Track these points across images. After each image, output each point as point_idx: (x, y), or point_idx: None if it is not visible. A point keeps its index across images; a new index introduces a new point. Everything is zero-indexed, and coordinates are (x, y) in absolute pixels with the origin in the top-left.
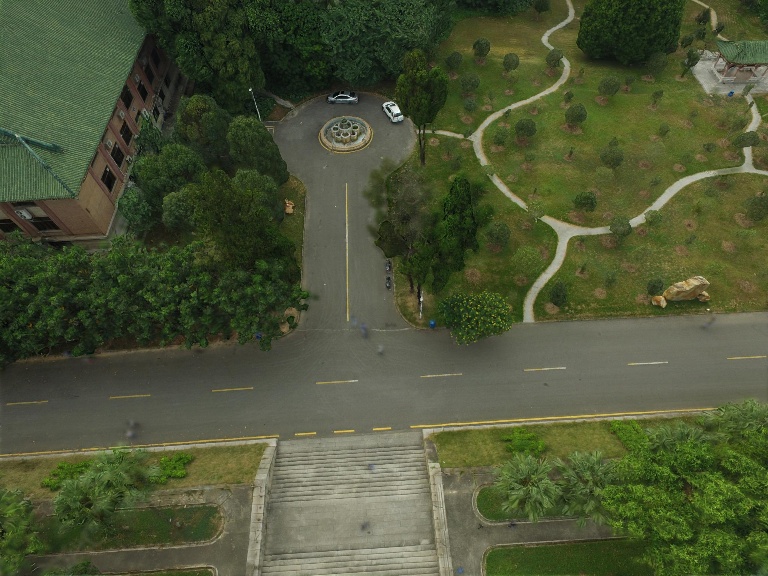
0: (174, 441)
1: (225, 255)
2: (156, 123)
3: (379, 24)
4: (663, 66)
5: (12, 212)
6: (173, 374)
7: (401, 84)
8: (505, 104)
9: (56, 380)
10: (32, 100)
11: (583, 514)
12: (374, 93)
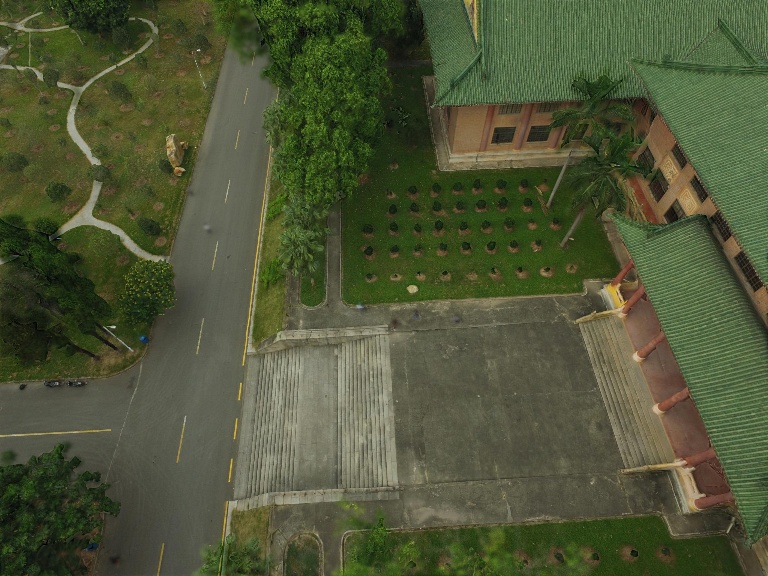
0: None
1: None
2: None
3: None
4: None
5: None
6: None
7: None
8: None
9: None
10: None
11: (325, 242)
12: None
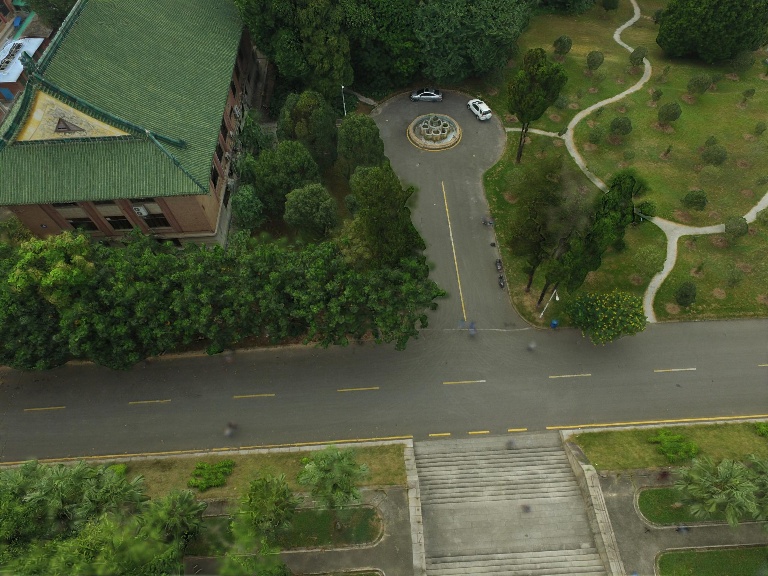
0: (306, 441)
1: (373, 253)
2: (243, 120)
3: (474, 21)
4: (751, 64)
5: (129, 209)
6: (295, 373)
7: (520, 81)
8: (591, 102)
9: (176, 379)
10: (153, 95)
11: (750, 518)
12: (456, 91)
